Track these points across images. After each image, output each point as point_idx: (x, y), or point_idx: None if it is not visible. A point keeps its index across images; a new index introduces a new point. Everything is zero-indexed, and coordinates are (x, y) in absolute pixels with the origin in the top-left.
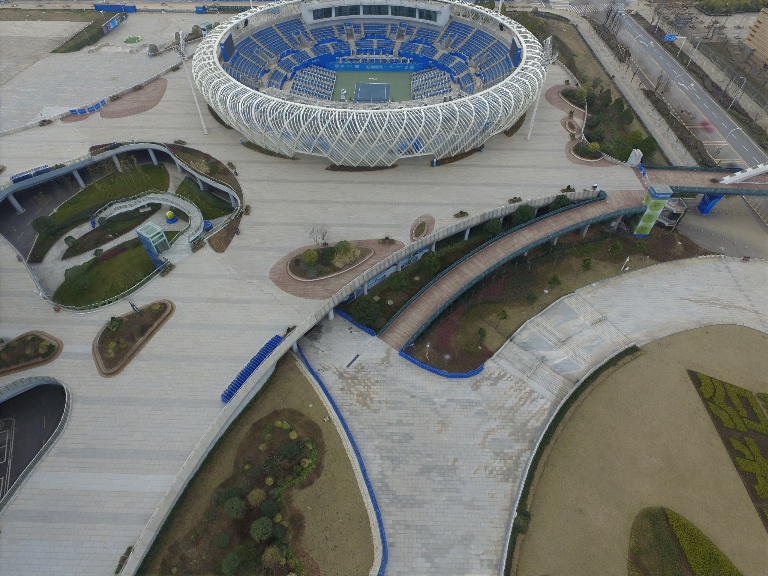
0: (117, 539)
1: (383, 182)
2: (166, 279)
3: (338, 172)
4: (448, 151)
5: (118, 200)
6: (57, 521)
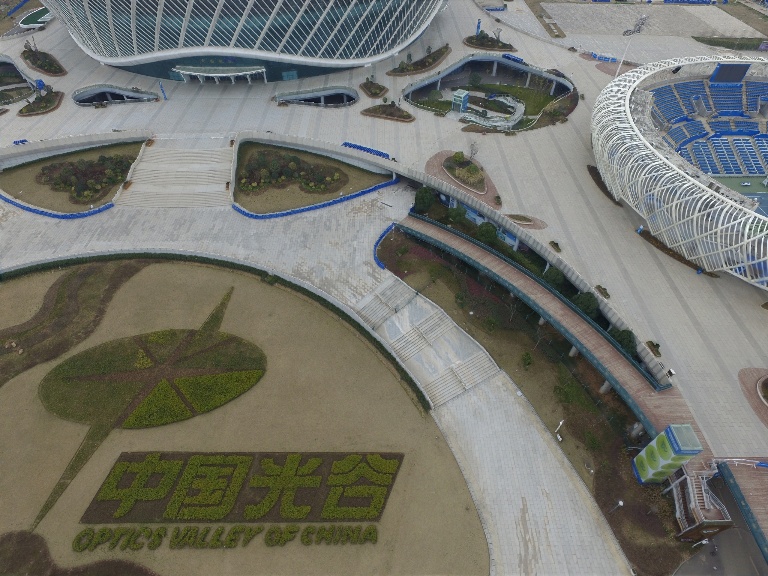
0: (279, 131)
1: (586, 198)
2: (432, 116)
3: (587, 172)
4: (662, 233)
5: (512, 96)
6: (289, 117)
